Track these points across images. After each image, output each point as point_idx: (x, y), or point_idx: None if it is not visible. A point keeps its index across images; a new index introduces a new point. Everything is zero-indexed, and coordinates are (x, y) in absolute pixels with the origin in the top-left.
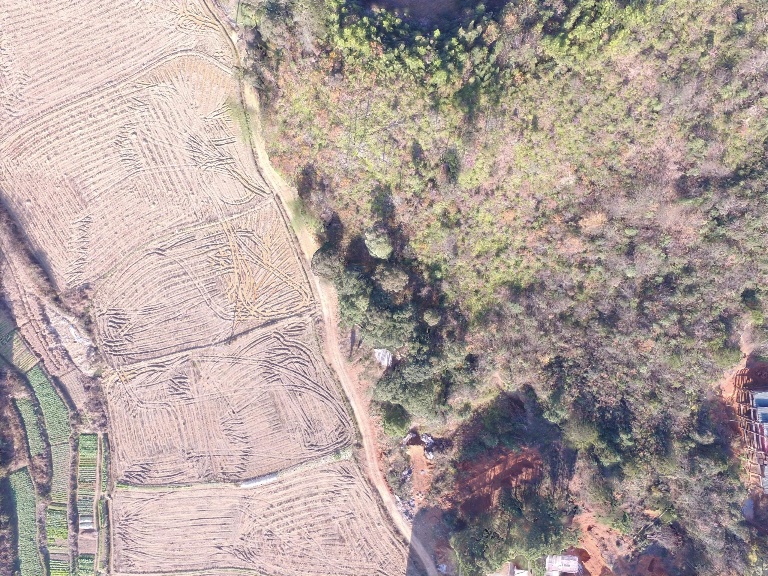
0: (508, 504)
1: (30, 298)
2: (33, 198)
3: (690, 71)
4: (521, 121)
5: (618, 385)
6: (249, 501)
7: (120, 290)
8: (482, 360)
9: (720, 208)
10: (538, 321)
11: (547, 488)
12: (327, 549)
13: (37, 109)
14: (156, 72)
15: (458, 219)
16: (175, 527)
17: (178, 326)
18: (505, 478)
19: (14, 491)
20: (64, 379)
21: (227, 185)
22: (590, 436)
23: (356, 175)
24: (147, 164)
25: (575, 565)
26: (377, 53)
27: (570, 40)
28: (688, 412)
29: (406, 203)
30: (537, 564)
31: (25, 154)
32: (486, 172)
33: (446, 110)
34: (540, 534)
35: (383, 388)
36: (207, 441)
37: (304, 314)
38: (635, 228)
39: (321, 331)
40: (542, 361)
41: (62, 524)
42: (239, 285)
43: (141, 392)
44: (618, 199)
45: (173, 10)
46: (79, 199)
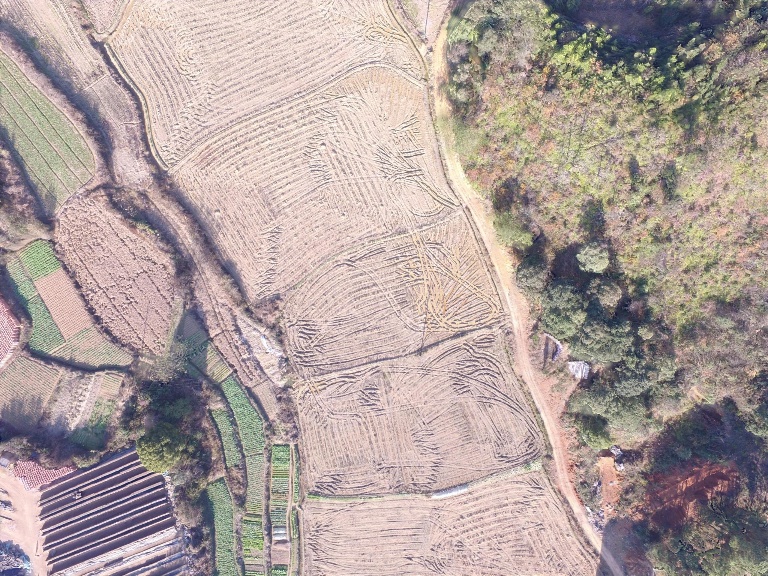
0: (708, 516)
1: (223, 309)
2: (222, 208)
3: None
4: (741, 138)
5: None
6: (439, 512)
7: (310, 301)
8: (689, 374)
9: None
10: (749, 336)
11: (745, 500)
12: (517, 560)
13: (226, 119)
14: (344, 83)
15: (669, 234)
16: (366, 538)
17: (368, 337)
18: (698, 490)
19: (212, 502)
20: (257, 390)
21: (416, 197)
22: None
23: (567, 190)
24: (336, 175)
25: None
26: (595, 69)
27: None
28: None
29: (619, 218)
30: None
31: (214, 164)
32: (703, 188)
33: (666, 127)
34: (764, 547)
35: (600, 402)
36: (398, 452)
37: (494, 326)
38: None
39: (511, 343)
40: (751, 375)
41: (258, 535)
42: (429, 297)
43: (332, 403)
44: None
45: (361, 21)
46: (268, 210)
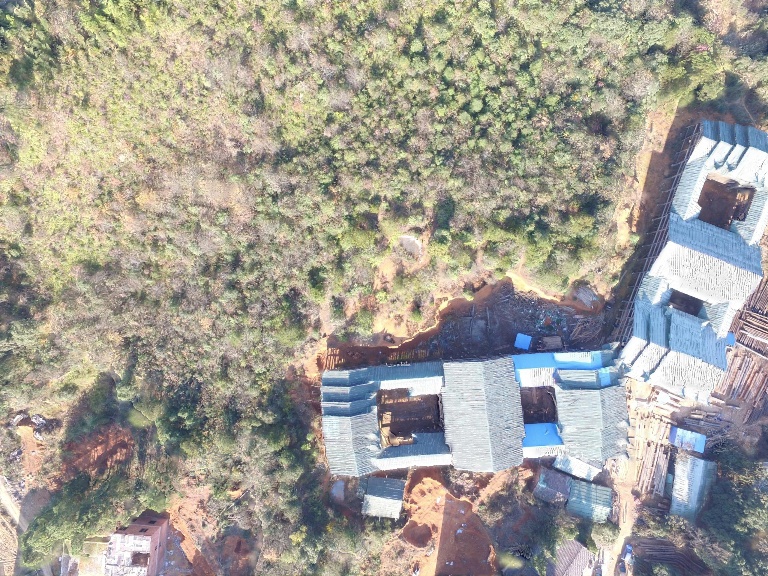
0: None
1: None
2: None
3: (234, 47)
4: (72, 98)
5: (187, 364)
6: None
7: None
8: (58, 339)
9: None
10: (103, 299)
11: (136, 468)
12: None
13: None
14: None
15: (27, 197)
16: None
17: None
18: (105, 459)
19: None
20: None
21: None
22: (148, 415)
23: None
24: None
25: (147, 545)
26: None
27: (105, 16)
28: (253, 391)
29: None
30: (72, 542)
31: None
32: (44, 149)
33: None
34: (74, 512)
35: None
36: None
37: None
38: (193, 205)
39: None
40: (111, 340)
41: None
42: None
43: None
44: (180, 177)
45: None
46: None
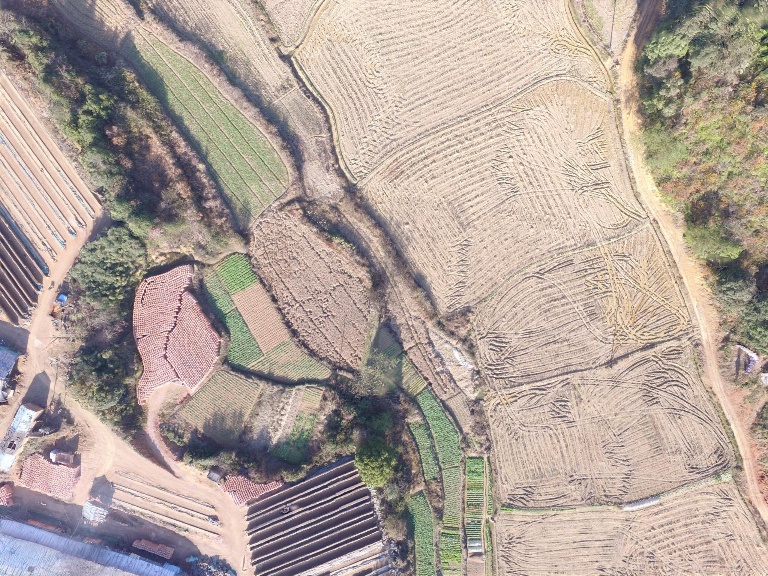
0: None
1: (417, 321)
2: (412, 221)
3: None
4: None
5: None
6: (631, 523)
7: (500, 313)
8: None
9: None
10: None
11: None
12: (708, 571)
13: (413, 132)
14: (530, 96)
15: None
16: (558, 550)
17: (558, 349)
18: None
19: (412, 515)
20: (450, 402)
21: (604, 209)
22: None
23: None
24: (524, 188)
25: None
26: None
27: None
28: None
29: None
30: None
31: (402, 177)
32: None
33: None
34: None
35: None
36: (589, 464)
37: (682, 338)
38: None
39: (701, 355)
40: None
41: (456, 548)
42: (617, 309)
43: (523, 415)
44: None
45: (546, 35)
46: (458, 222)
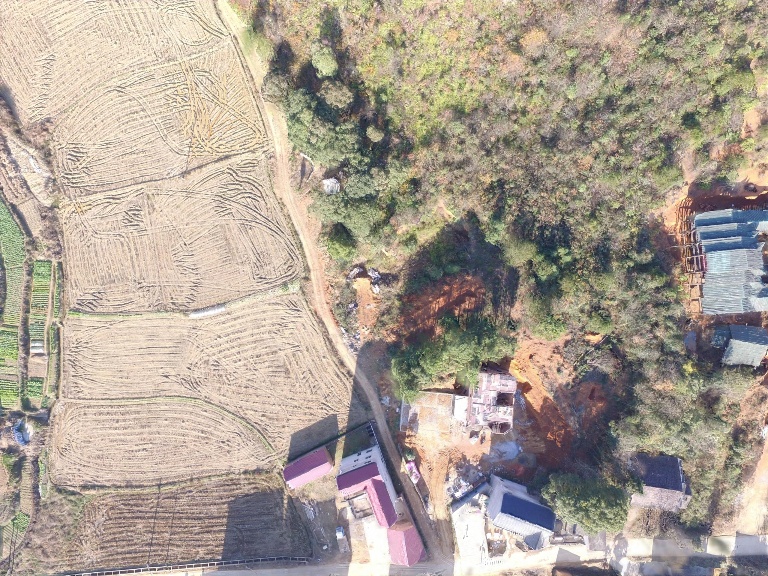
0: None
1: None
2: (0, 36)
3: None
4: None
5: (558, 206)
6: (197, 331)
7: (80, 125)
8: (425, 181)
9: (658, 26)
10: (479, 140)
11: (489, 315)
12: (272, 381)
13: None
14: None
15: (403, 41)
16: (124, 355)
17: (134, 160)
18: (449, 309)
19: None
20: (22, 207)
21: (187, 27)
22: (528, 250)
23: None
24: (111, 6)
25: (513, 385)
26: None
27: None
28: (627, 232)
29: (352, 24)
30: (470, 366)
31: None
32: None
33: None
34: (473, 336)
35: (324, 199)
36: (158, 272)
37: (257, 151)
38: (575, 47)
39: (273, 166)
40: (483, 181)
41: (13, 345)
42: (195, 122)
43: (96, 223)
44: (559, 21)
45: None
46: (44, 38)
